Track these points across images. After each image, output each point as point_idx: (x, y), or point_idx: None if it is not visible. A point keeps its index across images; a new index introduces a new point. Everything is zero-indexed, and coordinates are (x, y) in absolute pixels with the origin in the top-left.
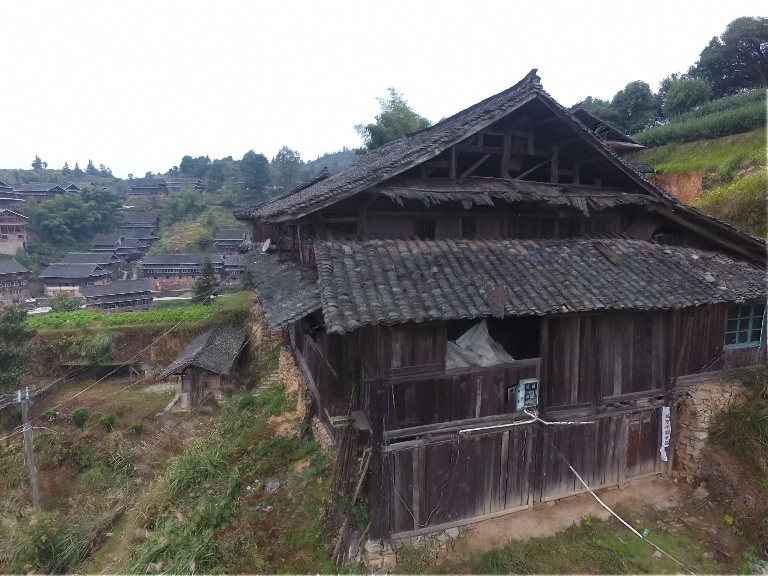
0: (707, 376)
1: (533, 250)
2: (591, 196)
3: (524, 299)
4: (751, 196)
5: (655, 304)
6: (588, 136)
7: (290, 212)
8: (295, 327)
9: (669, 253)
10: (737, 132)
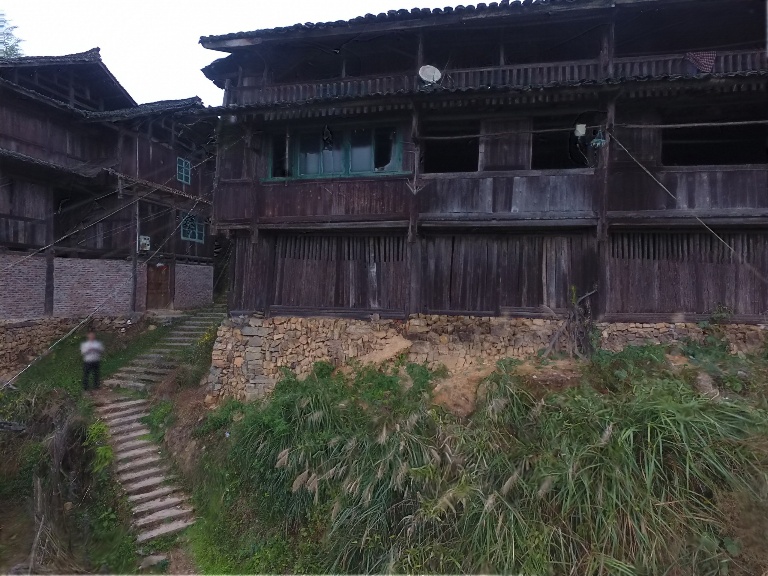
0: None
1: None
2: None
3: None
4: None
5: None
6: None
7: None
8: (587, 186)
9: None
10: None
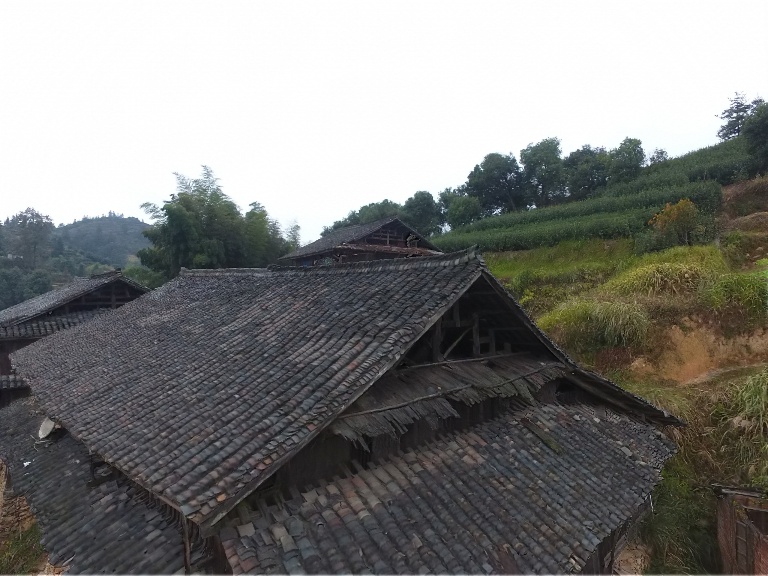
0: (621, 544)
1: (485, 452)
2: (525, 375)
3: (535, 565)
4: (577, 328)
5: (623, 513)
6: (519, 311)
7: (200, 521)
8: None
9: (580, 420)
10: (516, 249)
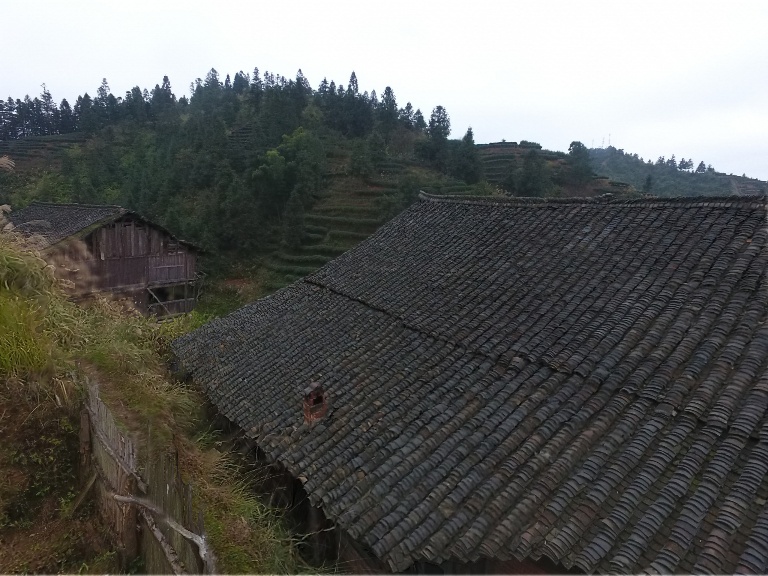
0: None
1: None
2: None
3: None
4: None
5: None
6: None
7: None
8: None
9: None
10: None
